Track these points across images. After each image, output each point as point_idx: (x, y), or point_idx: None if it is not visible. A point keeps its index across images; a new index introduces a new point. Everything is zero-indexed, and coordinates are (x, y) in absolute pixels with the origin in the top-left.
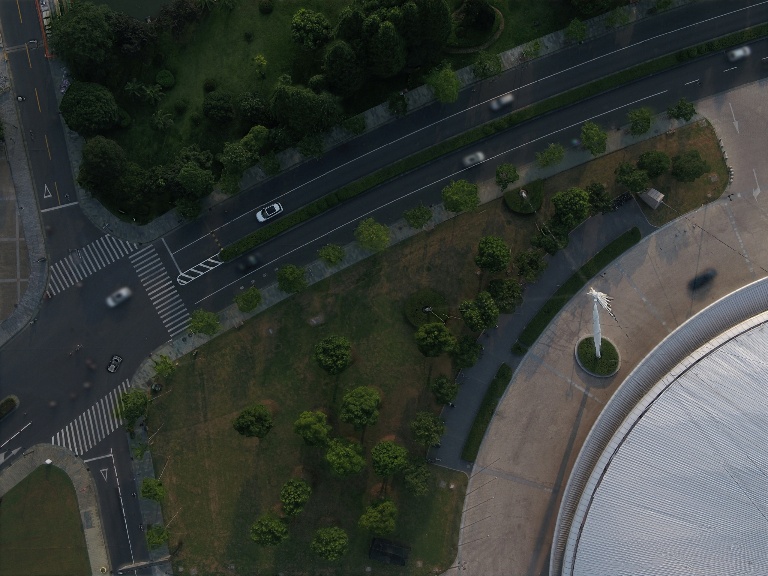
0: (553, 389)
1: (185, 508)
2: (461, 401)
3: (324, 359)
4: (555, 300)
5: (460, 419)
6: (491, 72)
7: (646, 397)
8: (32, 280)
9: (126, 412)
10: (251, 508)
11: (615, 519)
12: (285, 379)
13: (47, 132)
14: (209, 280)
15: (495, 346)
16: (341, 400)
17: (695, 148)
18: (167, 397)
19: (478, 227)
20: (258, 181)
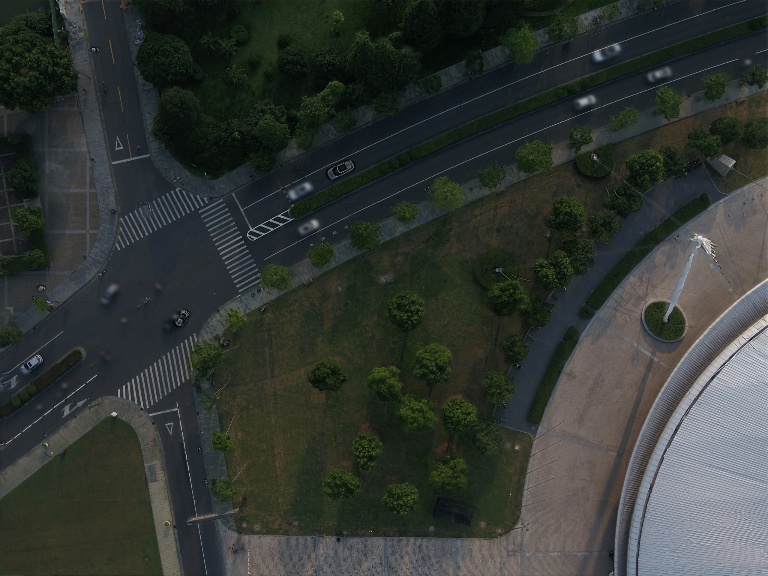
0: (619, 353)
1: (250, 464)
2: (528, 363)
3: (399, 314)
4: (623, 264)
5: (526, 381)
6: (568, 34)
7: (718, 359)
8: (101, 232)
9: (201, 362)
10: (316, 465)
11: (686, 479)
12: (353, 337)
13: (120, 84)
14: (279, 236)
15: (562, 309)
16: (409, 359)
17: (765, 117)
18: (234, 352)
19: (548, 190)
20: (330, 138)
